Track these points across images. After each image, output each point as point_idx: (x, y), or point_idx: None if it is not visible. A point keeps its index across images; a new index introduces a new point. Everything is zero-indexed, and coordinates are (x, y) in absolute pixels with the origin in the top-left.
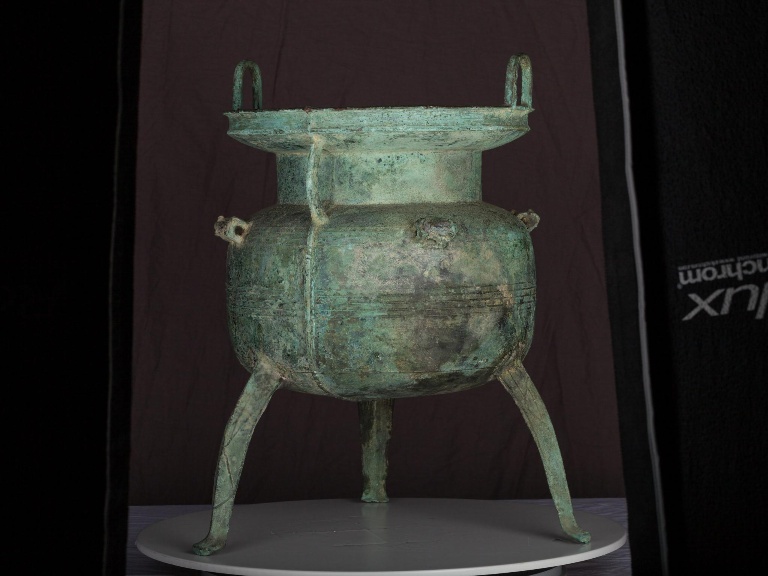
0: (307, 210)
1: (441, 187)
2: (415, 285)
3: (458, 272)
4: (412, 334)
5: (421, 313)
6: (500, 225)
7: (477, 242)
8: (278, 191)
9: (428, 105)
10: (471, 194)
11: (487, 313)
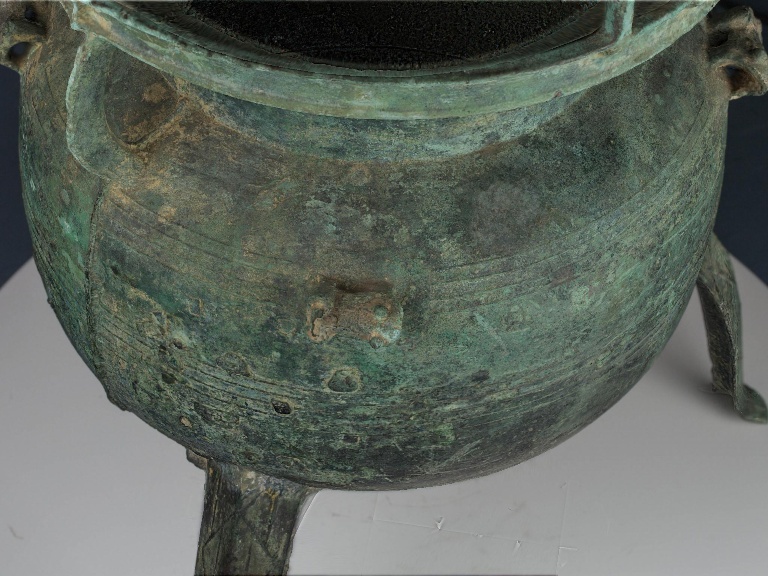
0: None
1: None
2: None
3: None
4: None
5: None
6: None
7: None
8: None
9: None
10: None
11: None
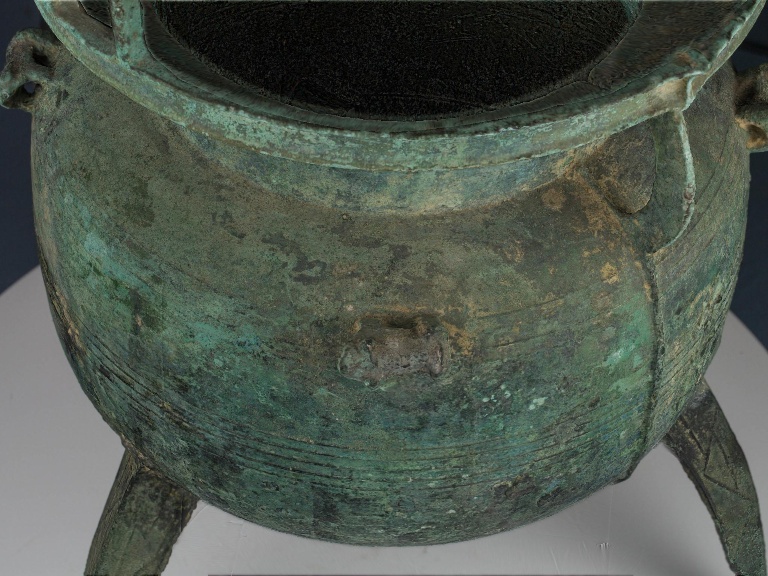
0: None
1: None
2: None
3: None
4: None
5: None
6: (92, 205)
7: (43, 170)
8: None
9: None
10: None
11: None
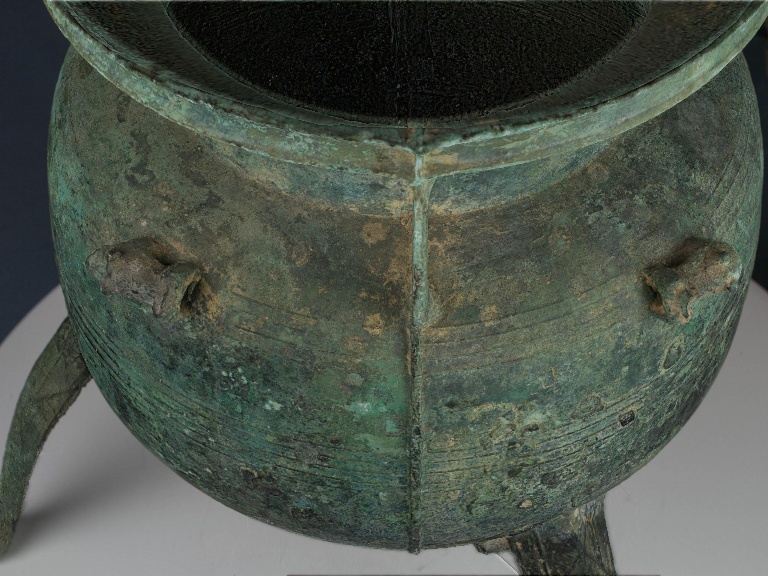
0: None
1: None
2: None
3: None
4: None
5: (193, 39)
6: None
7: None
8: None
9: None
10: None
11: None
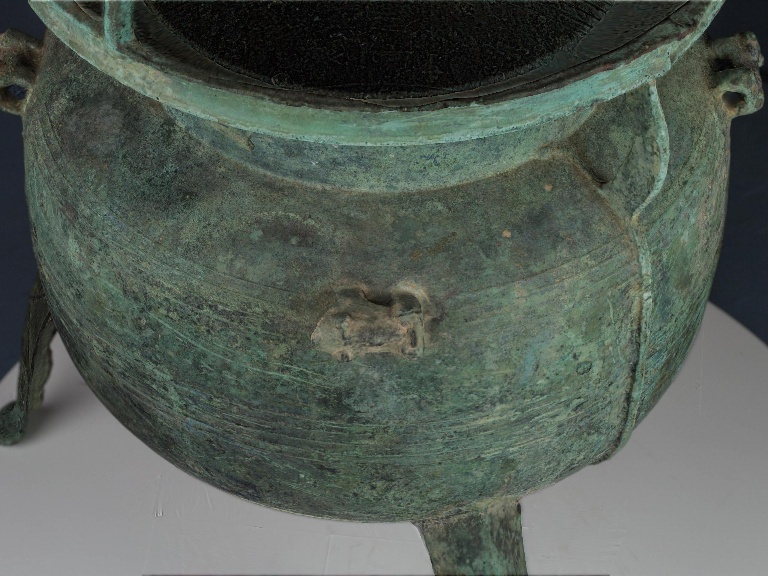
0: (542, 194)
1: None
2: None
3: None
4: None
5: None
6: None
7: None
8: (338, 166)
9: None
10: None
11: None
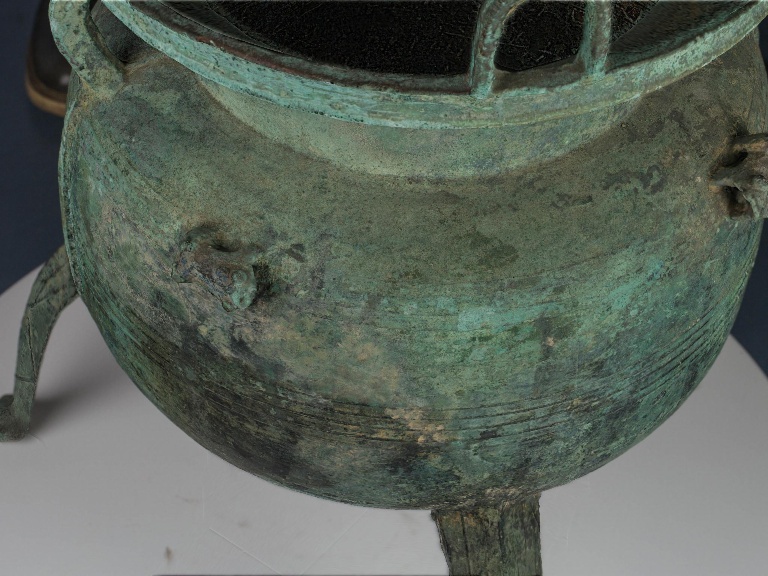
0: None
1: (361, 140)
2: (183, 336)
3: (273, 359)
4: (183, 405)
5: (195, 385)
6: (445, 290)
7: (337, 320)
8: None
9: (205, 36)
10: (476, 160)
11: (351, 444)
